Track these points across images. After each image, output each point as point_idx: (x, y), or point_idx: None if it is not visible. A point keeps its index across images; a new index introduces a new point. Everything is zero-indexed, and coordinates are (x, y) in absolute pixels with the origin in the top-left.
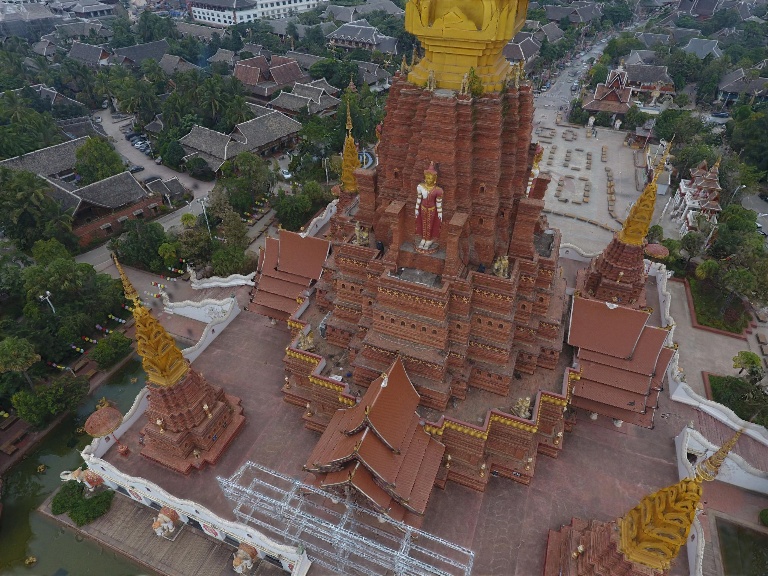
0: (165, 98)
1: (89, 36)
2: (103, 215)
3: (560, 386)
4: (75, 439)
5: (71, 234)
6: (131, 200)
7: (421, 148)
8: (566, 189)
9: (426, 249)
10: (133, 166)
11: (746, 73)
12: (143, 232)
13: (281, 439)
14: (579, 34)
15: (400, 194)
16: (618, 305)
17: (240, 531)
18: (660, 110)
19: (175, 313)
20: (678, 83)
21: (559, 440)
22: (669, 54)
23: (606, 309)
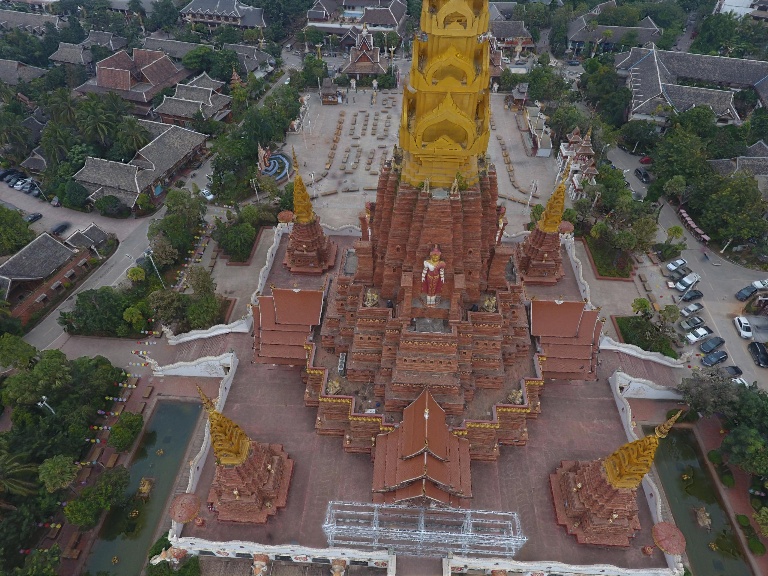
0: (29, 123)
1: None
2: (35, 288)
3: (534, 369)
4: (132, 523)
5: (11, 318)
6: (60, 264)
7: (425, 235)
8: None
9: (433, 304)
10: (28, 215)
11: (587, 21)
12: (100, 302)
13: (330, 468)
14: None
15: (405, 265)
16: (546, 279)
17: (334, 553)
18: (527, 68)
19: (166, 375)
20: (535, 35)
21: (538, 406)
22: (525, 11)
23: (555, 305)
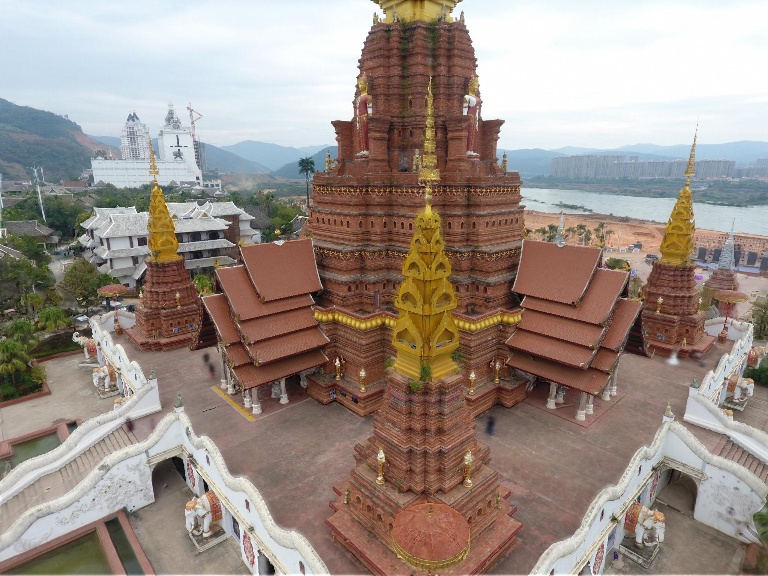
0: None
1: None
2: None
3: None
4: None
5: None
6: None
7: None
8: None
9: None
10: None
11: None
12: None
13: None
14: None
15: None
16: None
17: None
18: None
19: None
20: None
21: None
22: None
23: None
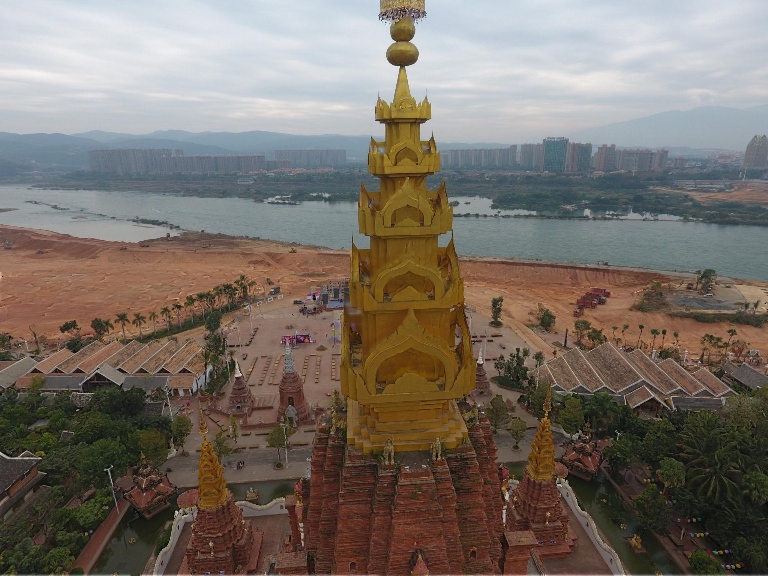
0: None
1: None
2: None
3: None
4: (618, 522)
5: None
6: None
7: None
8: None
9: None
10: None
11: None
12: None
13: None
14: None
15: None
16: None
17: None
18: None
19: None
20: None
21: None
22: None
23: None
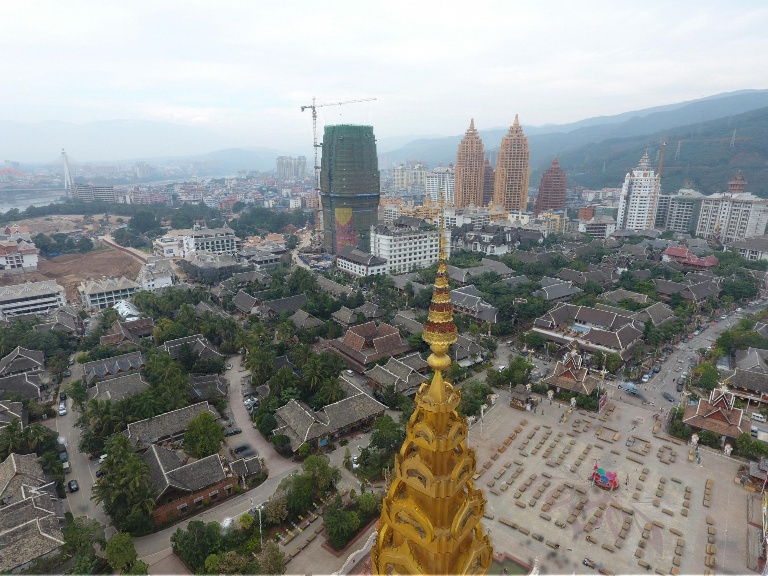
0: (282, 360)
1: (253, 283)
2: (183, 496)
3: None
4: None
5: (150, 517)
6: (210, 483)
7: None
8: (651, 545)
9: None
10: (233, 428)
11: None
12: (200, 536)
13: None
14: (692, 313)
15: None
16: None
17: None
18: None
19: None
20: None
21: None
22: None
23: None
